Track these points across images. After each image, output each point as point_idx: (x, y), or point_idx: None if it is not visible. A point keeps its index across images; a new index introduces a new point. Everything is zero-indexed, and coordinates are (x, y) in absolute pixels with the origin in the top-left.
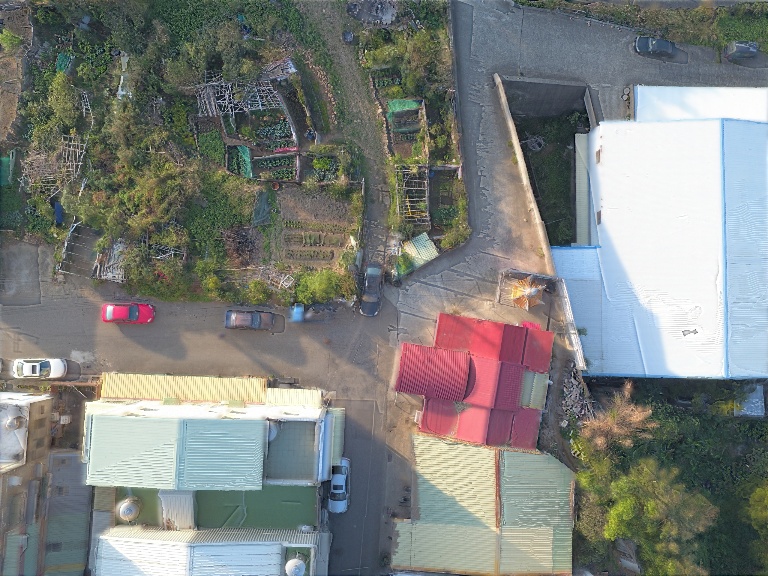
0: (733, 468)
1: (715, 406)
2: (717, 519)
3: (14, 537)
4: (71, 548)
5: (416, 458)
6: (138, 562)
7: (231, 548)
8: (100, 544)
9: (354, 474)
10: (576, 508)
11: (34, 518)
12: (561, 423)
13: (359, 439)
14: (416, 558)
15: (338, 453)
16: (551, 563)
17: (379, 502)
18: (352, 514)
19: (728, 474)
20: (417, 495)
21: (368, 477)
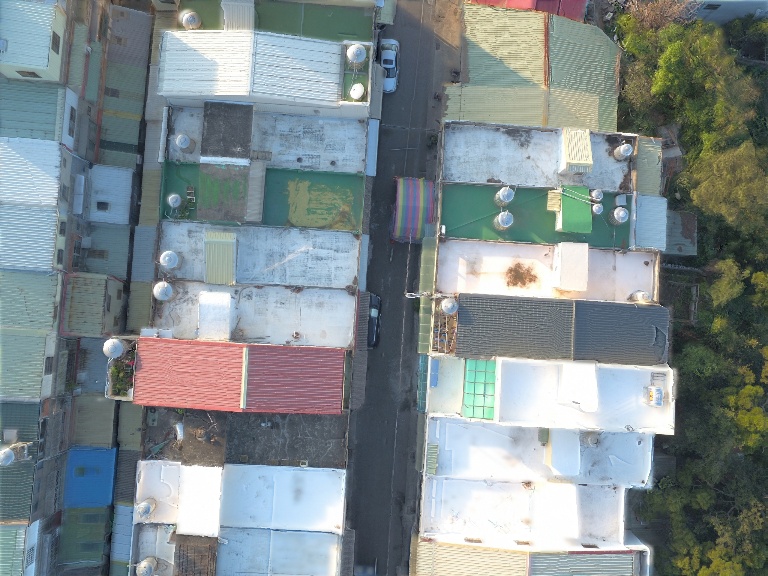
0: (767, 121)
1: (754, 25)
2: (758, 99)
3: (81, 27)
4: (128, 99)
5: (466, 27)
6: (202, 51)
7: (293, 41)
8: (165, 38)
9: (403, 60)
10: (621, 82)
11: (97, 37)
12: (606, 15)
13: (408, 27)
14: (465, 118)
15: (391, 12)
16: (597, 125)
17: (427, 87)
18: (400, 97)
19: (762, 123)
20: (467, 59)
21: (416, 63)
